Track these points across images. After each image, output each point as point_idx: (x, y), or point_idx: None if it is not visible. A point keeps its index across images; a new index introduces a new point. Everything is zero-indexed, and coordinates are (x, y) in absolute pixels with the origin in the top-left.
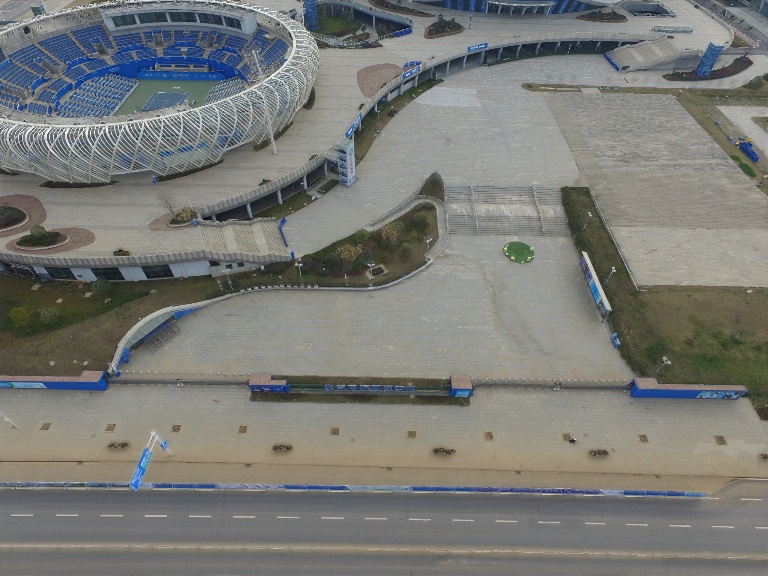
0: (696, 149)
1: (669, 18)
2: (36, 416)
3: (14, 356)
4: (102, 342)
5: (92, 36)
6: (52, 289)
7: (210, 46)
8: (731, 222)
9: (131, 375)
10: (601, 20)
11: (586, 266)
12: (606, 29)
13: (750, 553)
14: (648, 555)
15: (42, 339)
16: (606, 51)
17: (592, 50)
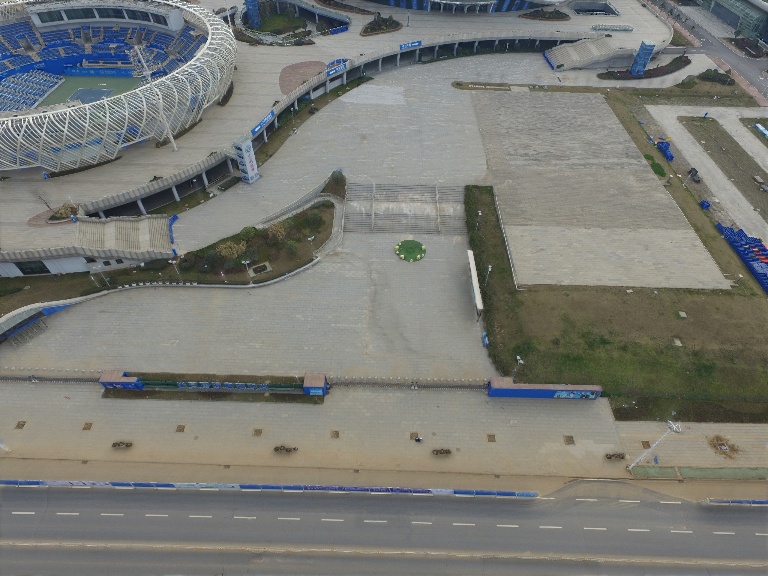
0: (611, 148)
1: (613, 17)
2: None
3: None
4: None
5: (18, 32)
6: None
7: (140, 43)
8: (628, 221)
9: None
10: (543, 18)
11: None
12: (546, 27)
13: (572, 554)
14: (467, 555)
15: None
16: (545, 50)
17: (531, 48)
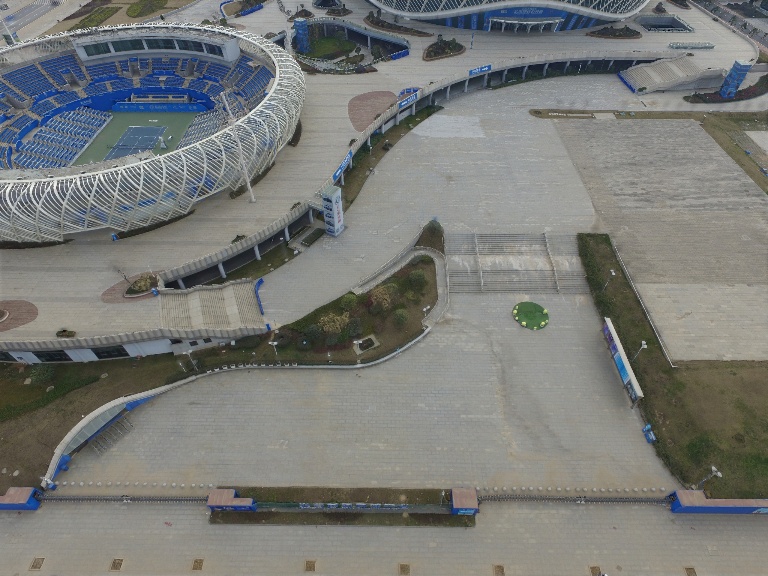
0: (727, 184)
1: (686, 33)
2: None
3: None
4: (37, 446)
5: (62, 67)
6: None
7: (191, 74)
8: None
9: (69, 488)
10: (613, 37)
11: (610, 335)
12: (619, 47)
13: None
14: None
15: None
16: (620, 70)
17: (604, 69)
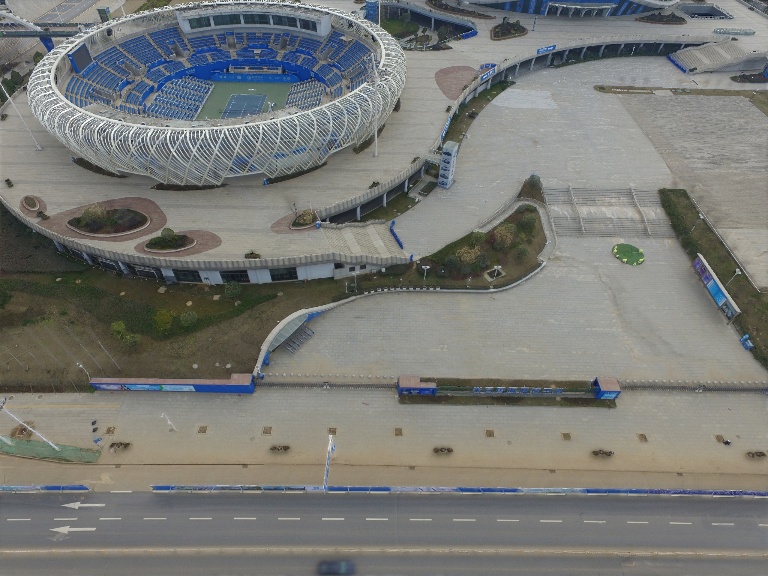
0: None
1: (727, 20)
2: (191, 419)
3: (157, 359)
4: (243, 345)
5: (168, 38)
6: (179, 292)
7: (282, 48)
8: None
9: (275, 378)
10: (661, 22)
11: (702, 268)
12: (668, 31)
13: None
14: None
15: (182, 342)
16: (669, 53)
17: (654, 52)
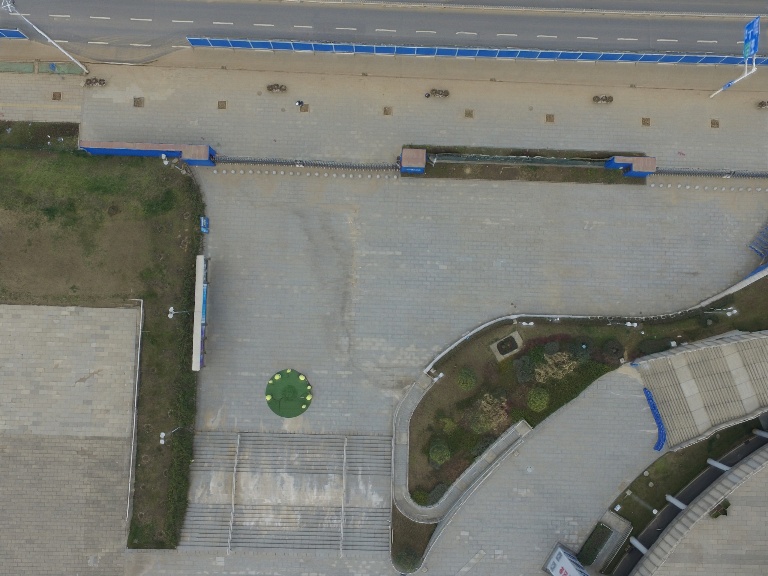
0: None
1: None
2: None
3: None
4: None
5: None
6: None
7: None
8: None
9: None
10: None
11: None
12: None
13: None
14: None
15: None
16: None
17: None
